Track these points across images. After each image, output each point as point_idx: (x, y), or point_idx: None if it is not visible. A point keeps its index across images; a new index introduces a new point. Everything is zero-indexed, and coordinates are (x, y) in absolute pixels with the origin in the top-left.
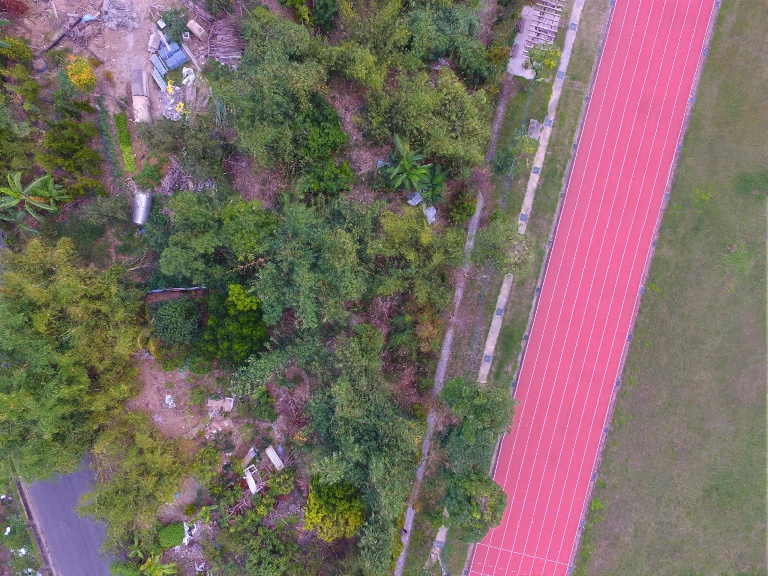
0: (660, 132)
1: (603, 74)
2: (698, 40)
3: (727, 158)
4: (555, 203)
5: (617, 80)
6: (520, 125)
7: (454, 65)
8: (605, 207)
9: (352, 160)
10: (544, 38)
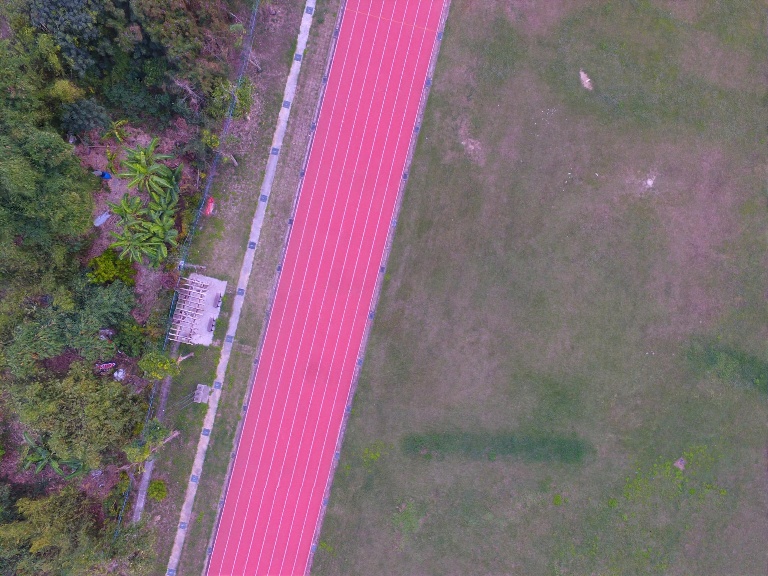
0: (329, 393)
1: (271, 338)
2: (364, 304)
3: (395, 419)
4: (226, 464)
5: (285, 343)
6: (188, 389)
7: (112, 338)
8: (276, 467)
9: (14, 430)
10: (190, 321)
